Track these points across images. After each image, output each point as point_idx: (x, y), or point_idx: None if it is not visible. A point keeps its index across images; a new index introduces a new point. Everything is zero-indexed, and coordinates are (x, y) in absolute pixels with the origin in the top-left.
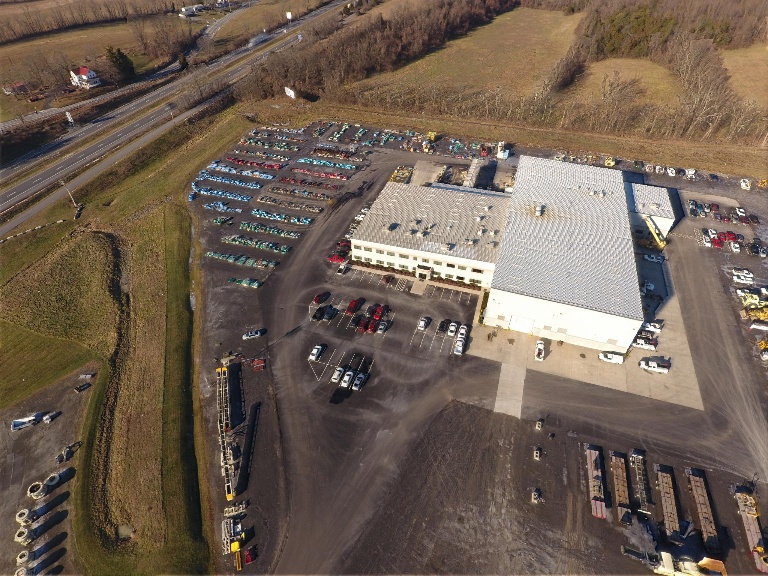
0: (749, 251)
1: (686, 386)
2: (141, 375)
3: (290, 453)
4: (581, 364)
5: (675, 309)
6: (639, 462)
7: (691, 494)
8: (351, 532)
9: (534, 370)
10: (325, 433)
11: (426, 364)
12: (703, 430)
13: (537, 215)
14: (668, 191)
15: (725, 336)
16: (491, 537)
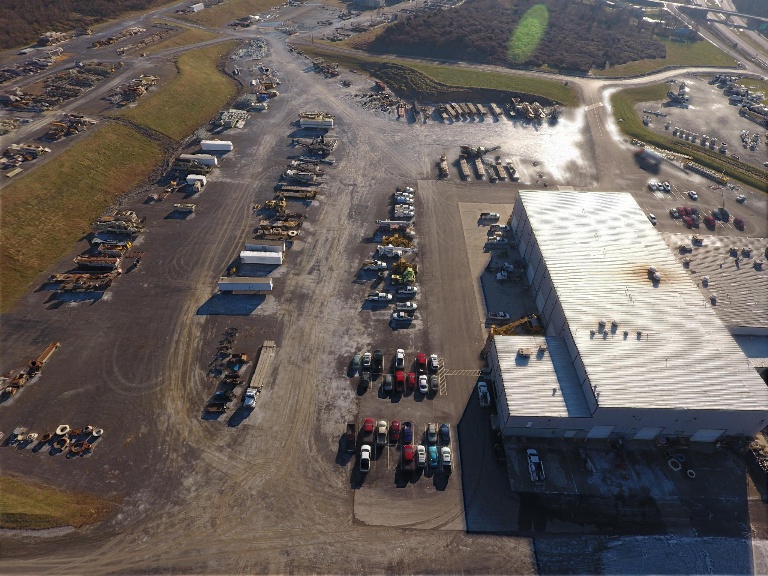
0: None
1: (468, 212)
2: (762, 180)
3: (648, 162)
4: None
5: (475, 264)
6: None
7: None
8: (598, 148)
9: None
10: (642, 169)
11: None
12: (460, 194)
13: None
14: (485, 513)
15: (436, 248)
16: (547, 154)
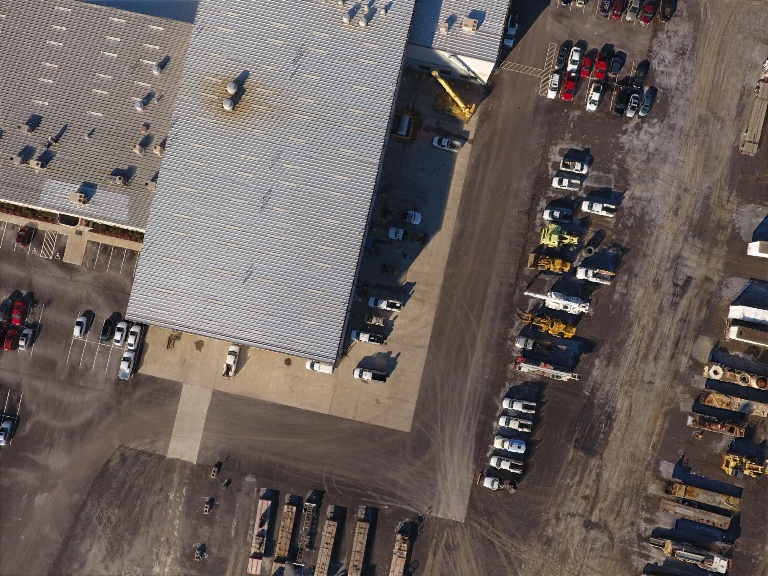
0: (613, 104)
1: (402, 398)
2: None
3: None
4: (282, 376)
5: (440, 259)
6: (310, 511)
7: (353, 538)
8: None
9: (222, 392)
10: None
11: (88, 395)
12: (397, 459)
13: (226, 109)
14: None
15: (488, 306)
16: None
